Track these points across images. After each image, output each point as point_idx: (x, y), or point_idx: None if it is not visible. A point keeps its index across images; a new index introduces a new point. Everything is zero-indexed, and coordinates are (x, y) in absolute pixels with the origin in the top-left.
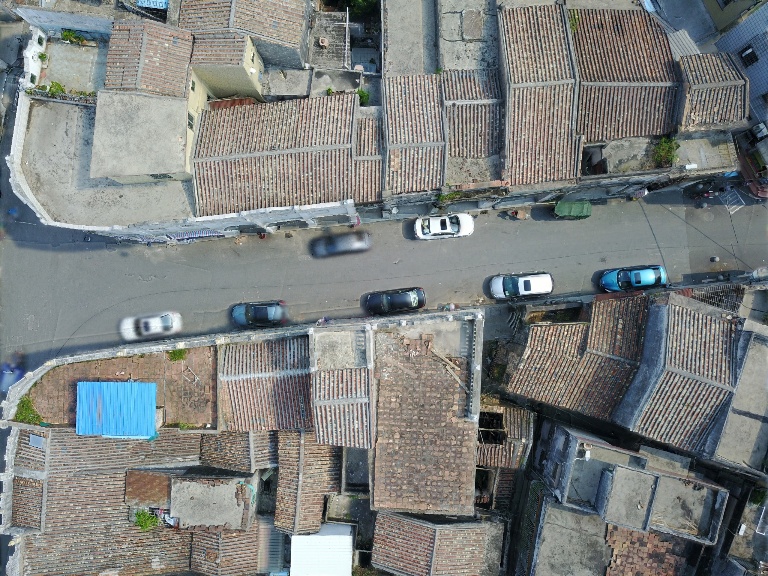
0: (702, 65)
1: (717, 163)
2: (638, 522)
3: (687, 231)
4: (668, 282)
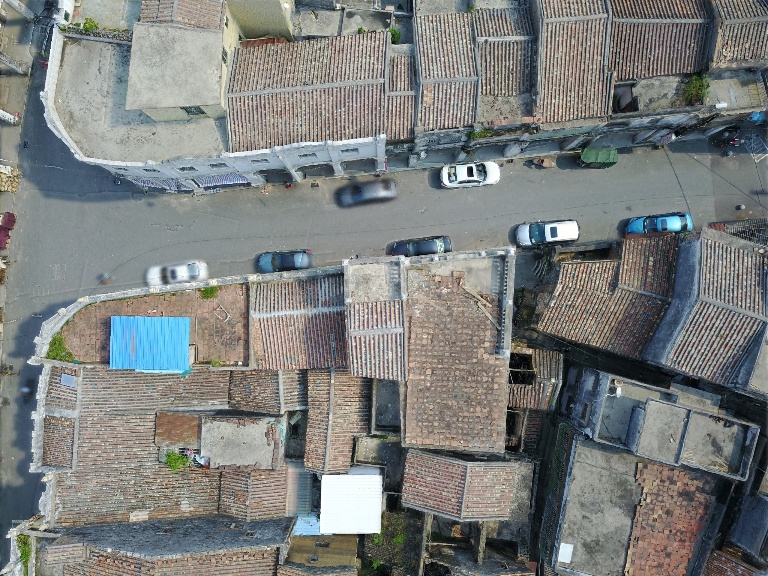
0: (733, 1)
1: (747, 103)
2: (670, 455)
3: (712, 179)
4: (694, 230)
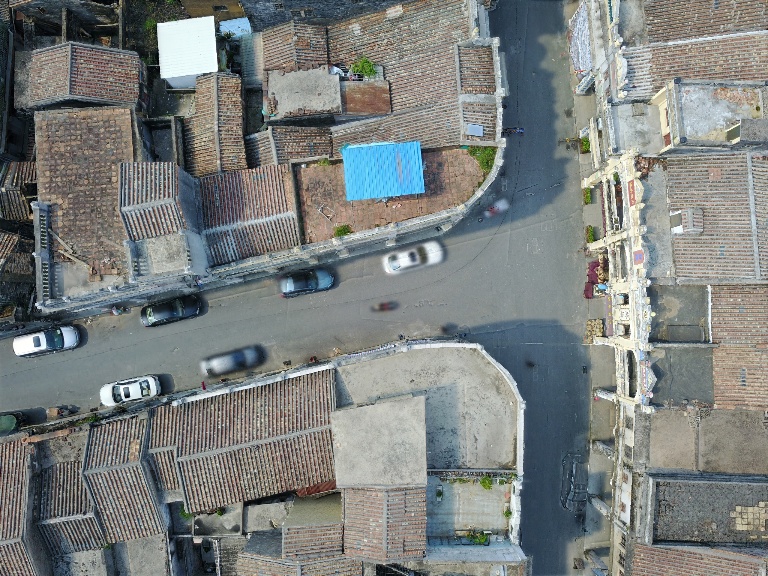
0: None
1: None
2: None
3: None
4: None
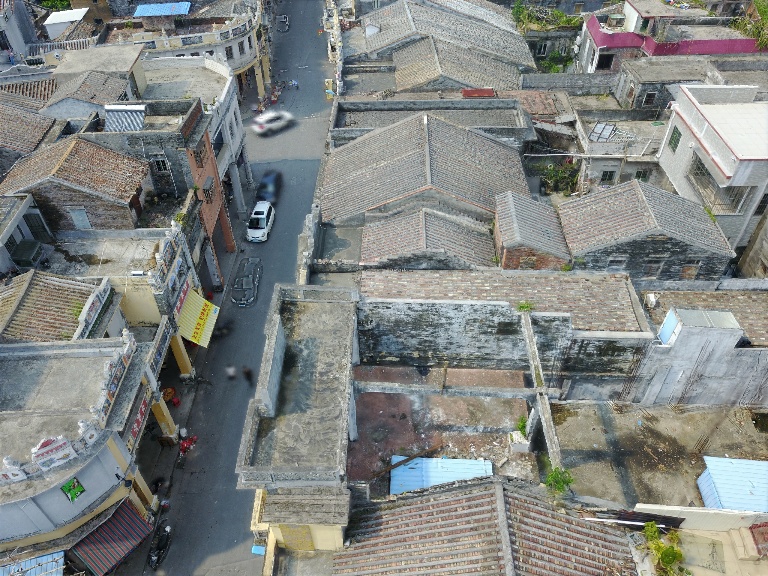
0: None
1: None
2: None
3: None
4: None
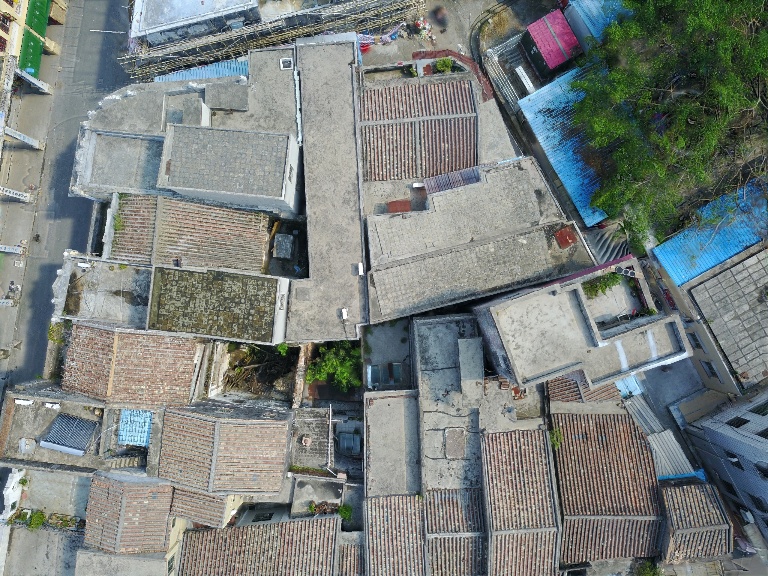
0: (686, 501)
1: (703, 574)
2: None
3: None
4: None
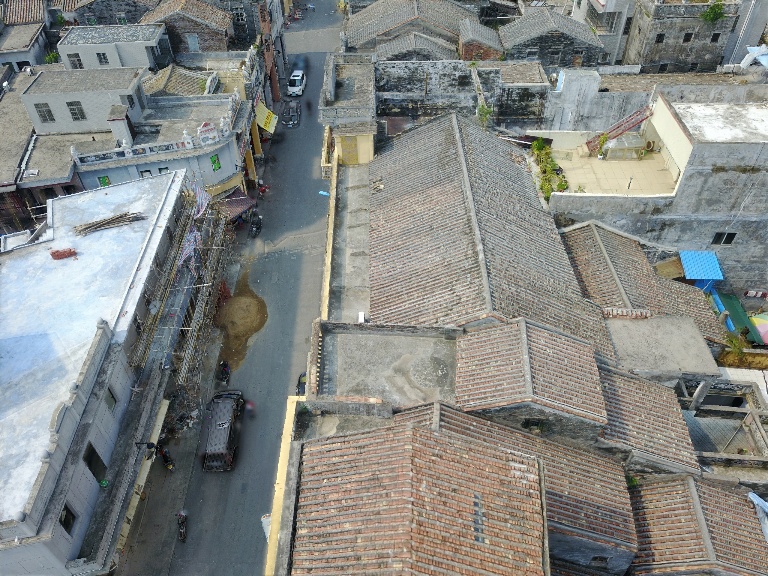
0: None
1: None
2: None
3: None
4: None
